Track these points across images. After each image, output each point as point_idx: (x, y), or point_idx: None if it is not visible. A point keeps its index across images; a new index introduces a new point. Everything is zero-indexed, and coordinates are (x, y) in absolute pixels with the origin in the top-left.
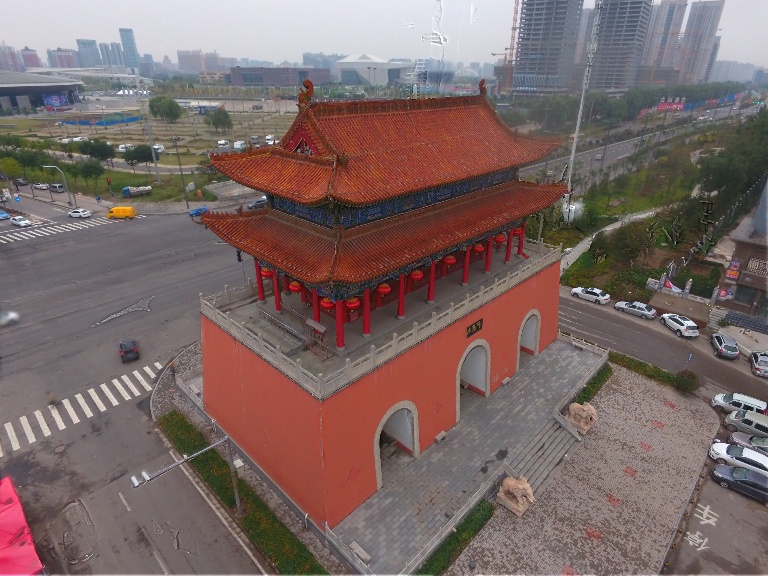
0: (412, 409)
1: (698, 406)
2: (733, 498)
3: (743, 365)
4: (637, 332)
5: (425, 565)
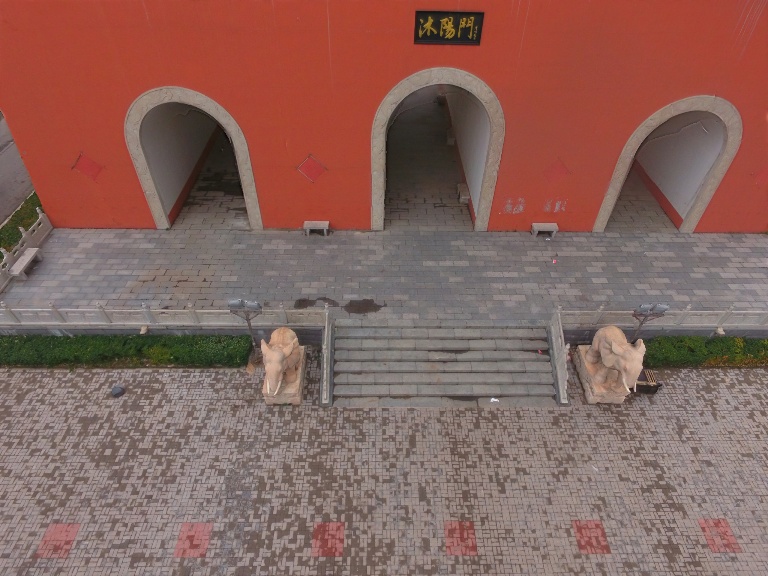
0: (228, 126)
1: None
2: None
3: None
4: None
5: (67, 337)
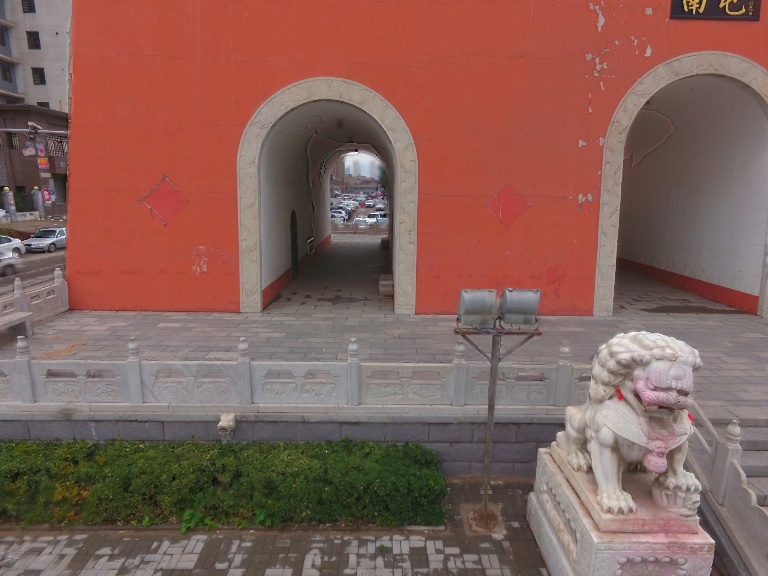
0: None
1: None
2: None
3: None
4: None
5: None
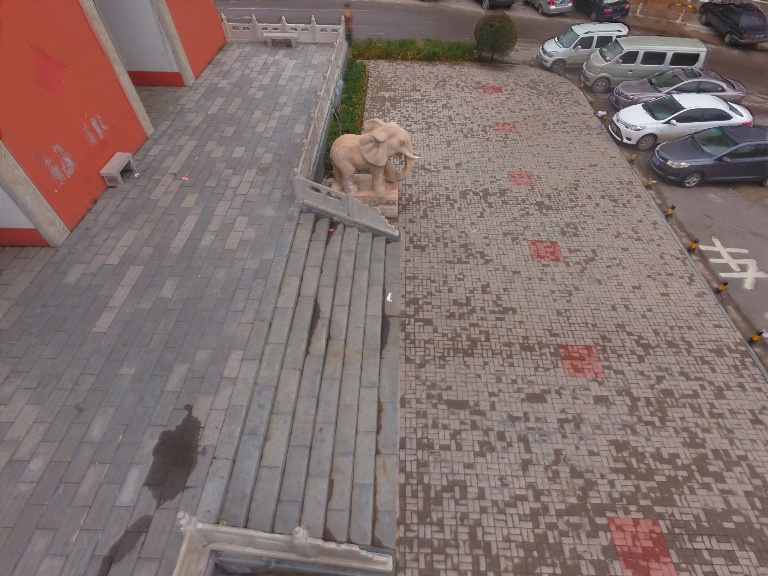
0: None
1: (530, 75)
2: (721, 199)
3: (524, 10)
4: (363, 10)
5: None
